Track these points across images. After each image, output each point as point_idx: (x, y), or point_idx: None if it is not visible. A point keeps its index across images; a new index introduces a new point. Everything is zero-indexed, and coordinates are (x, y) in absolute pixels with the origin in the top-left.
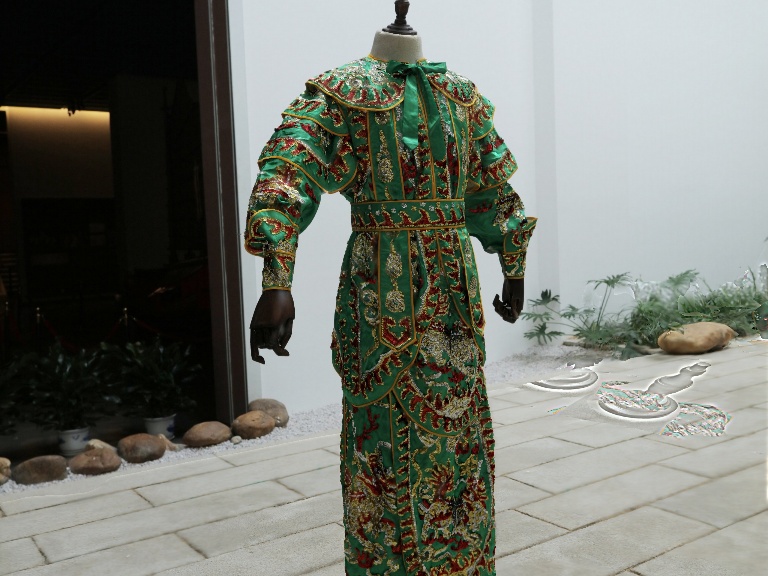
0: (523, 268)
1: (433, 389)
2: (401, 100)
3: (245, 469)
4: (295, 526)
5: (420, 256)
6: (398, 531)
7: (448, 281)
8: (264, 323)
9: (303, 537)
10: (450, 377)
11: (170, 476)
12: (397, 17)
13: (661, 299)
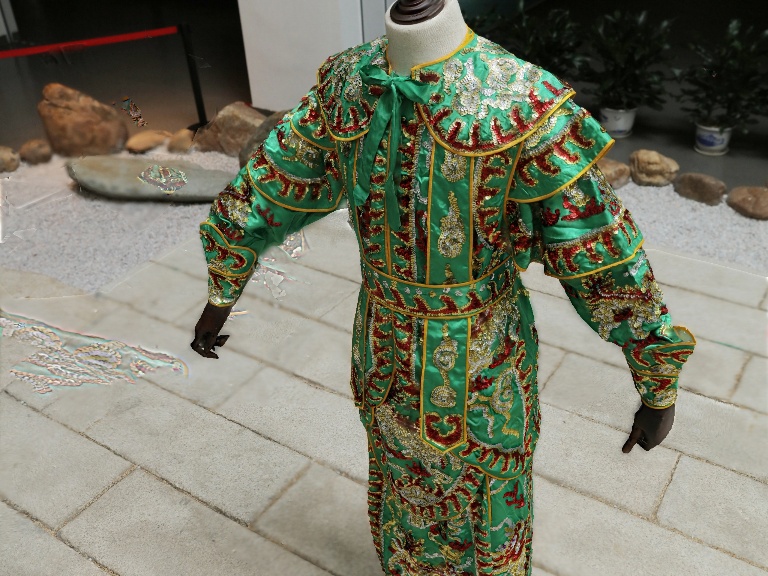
0: (659, 397)
1: None
2: (367, 130)
3: (756, 318)
4: None
5: (369, 331)
6: None
7: None
8: None
9: None
10: (409, 465)
11: (684, 281)
12: None
13: None
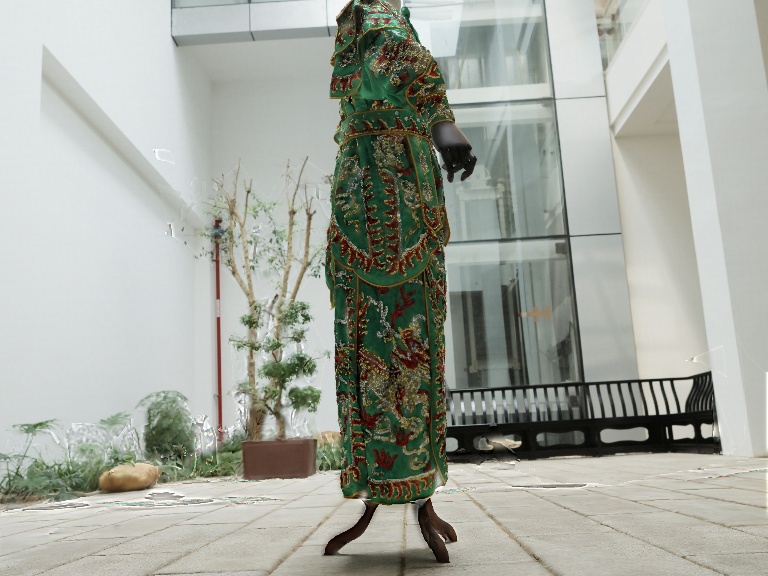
0: None
1: (443, 275)
2: None
3: None
4: (46, 563)
5: (436, 161)
6: (430, 402)
7: None
8: (462, 142)
9: (82, 563)
10: None
11: None
12: None
13: (98, 440)
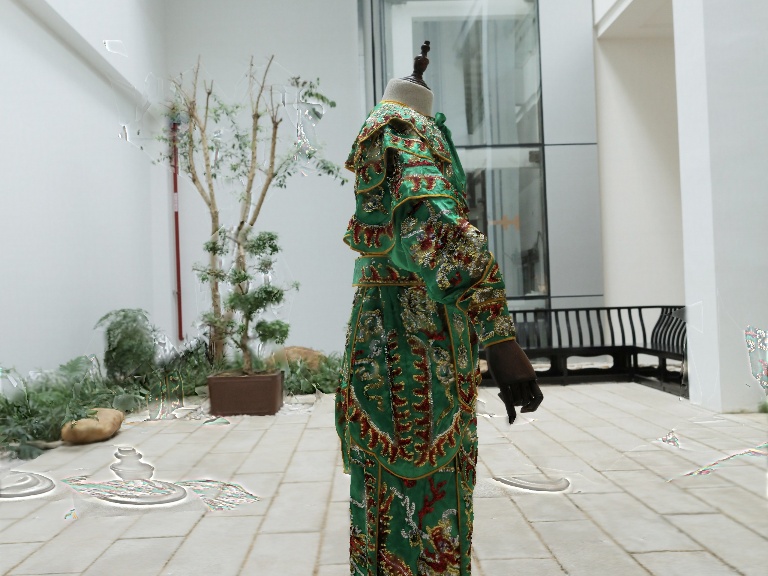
0: None
1: (475, 445)
2: None
3: None
4: None
5: None
6: None
7: None
8: (526, 376)
9: None
10: None
11: None
12: (417, 72)
13: (58, 388)
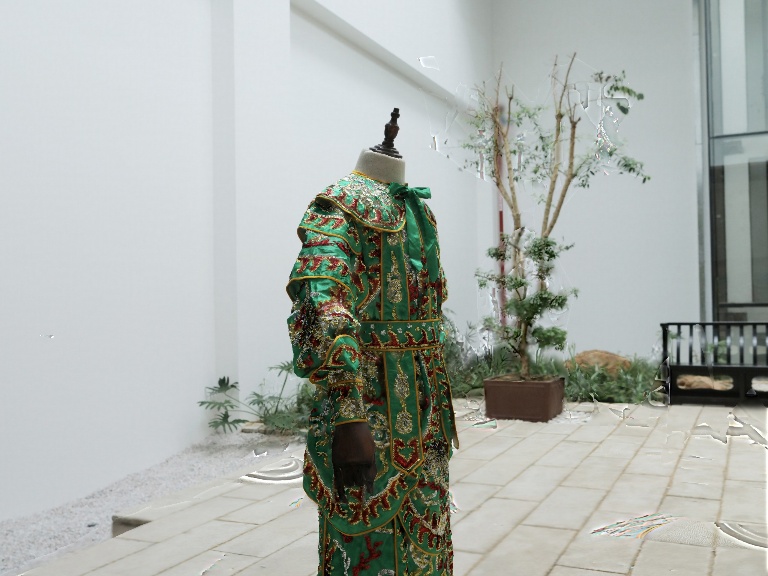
0: None
1: (431, 508)
2: (404, 222)
3: None
4: None
5: (424, 376)
6: None
7: (440, 399)
8: (357, 460)
9: None
10: (439, 494)
11: None
12: (386, 139)
13: None
